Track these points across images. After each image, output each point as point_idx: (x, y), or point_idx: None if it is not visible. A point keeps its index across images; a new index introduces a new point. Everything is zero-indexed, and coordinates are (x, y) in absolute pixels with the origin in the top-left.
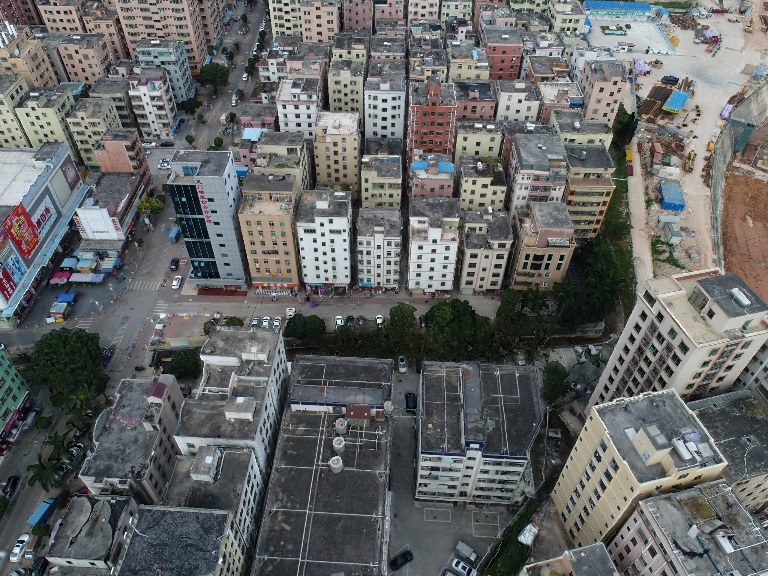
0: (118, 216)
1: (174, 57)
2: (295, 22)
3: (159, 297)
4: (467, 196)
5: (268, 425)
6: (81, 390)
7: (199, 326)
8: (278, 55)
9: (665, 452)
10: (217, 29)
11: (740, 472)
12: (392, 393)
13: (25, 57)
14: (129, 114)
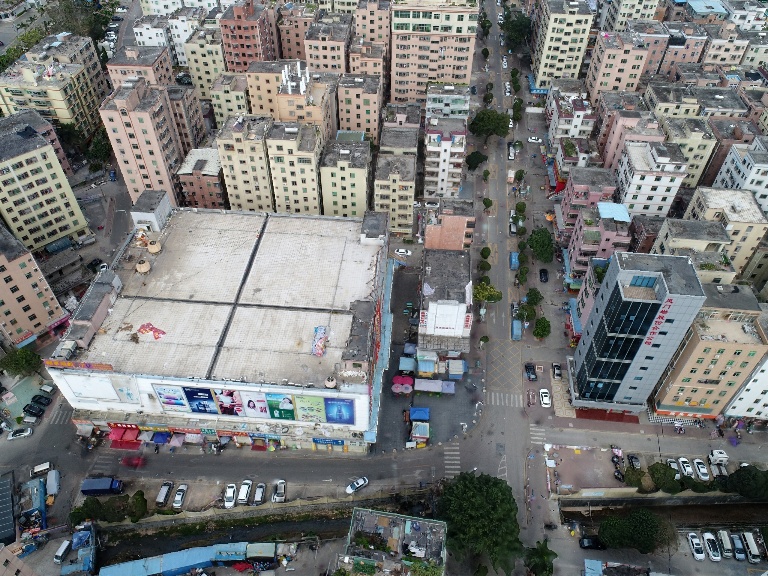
0: None
1: None
2: (569, 62)
3: (529, 418)
4: None
5: None
6: None
7: (599, 465)
8: (584, 106)
9: None
10: None
11: None
12: None
13: (322, 105)
14: (416, 170)
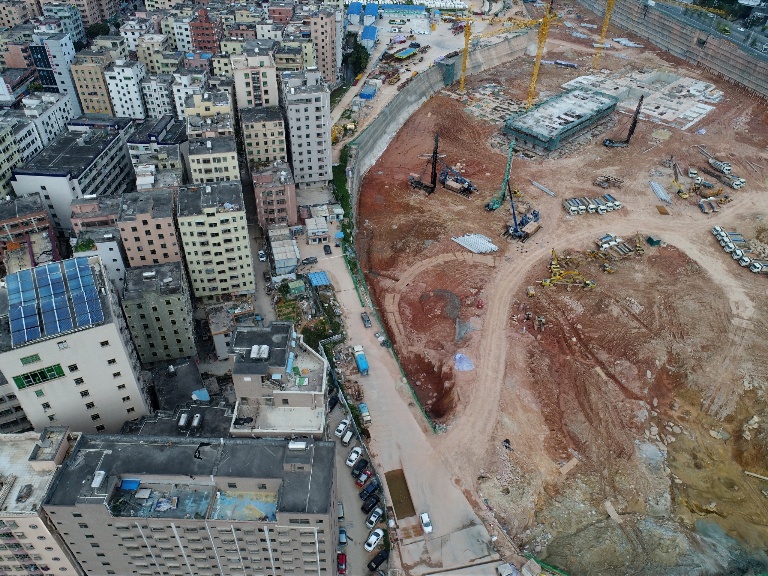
0: (11, 84)
1: (68, 13)
2: None
3: None
4: (217, 72)
5: (52, 130)
6: None
7: None
8: None
9: (200, 98)
10: (111, 10)
11: (248, 121)
12: None
13: None
14: None
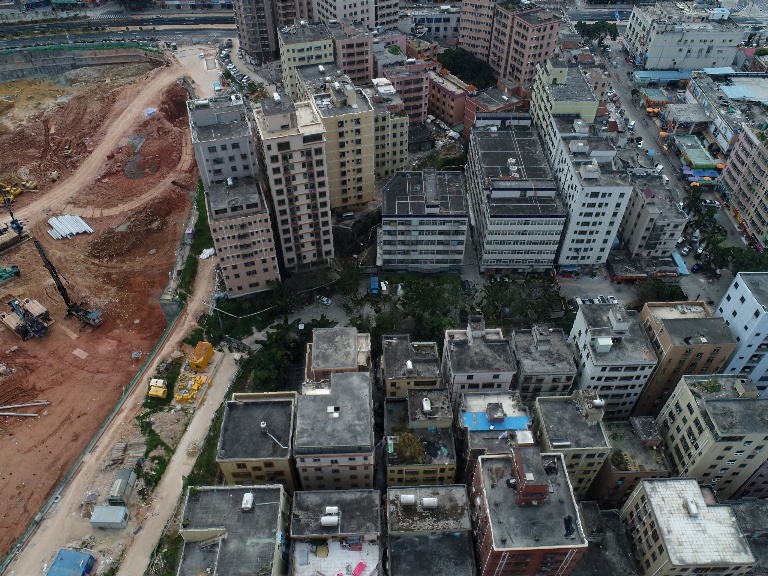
0: None
1: None
2: None
3: None
4: None
5: None
6: (722, 239)
7: None
8: None
9: None
10: None
11: None
12: (485, 249)
13: None
14: None
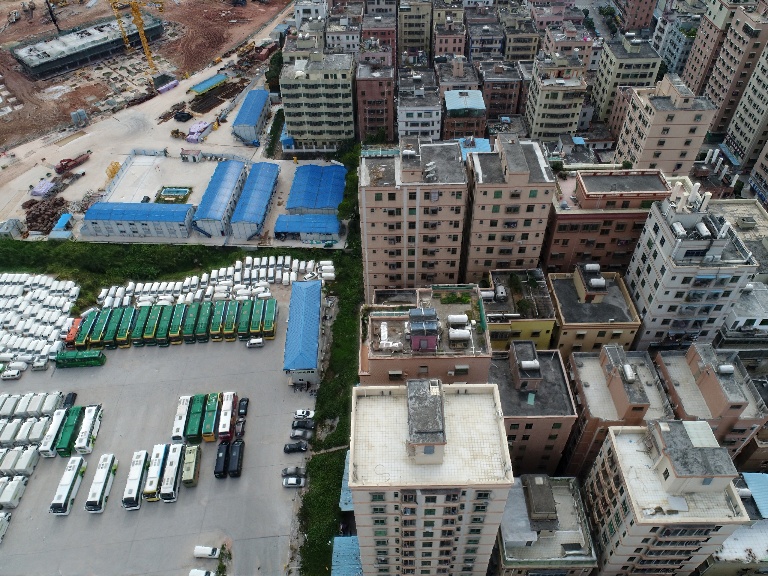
0: None
1: None
2: None
3: None
4: None
5: None
6: None
7: None
8: None
9: None
10: None
11: None
12: None
13: None
14: None
